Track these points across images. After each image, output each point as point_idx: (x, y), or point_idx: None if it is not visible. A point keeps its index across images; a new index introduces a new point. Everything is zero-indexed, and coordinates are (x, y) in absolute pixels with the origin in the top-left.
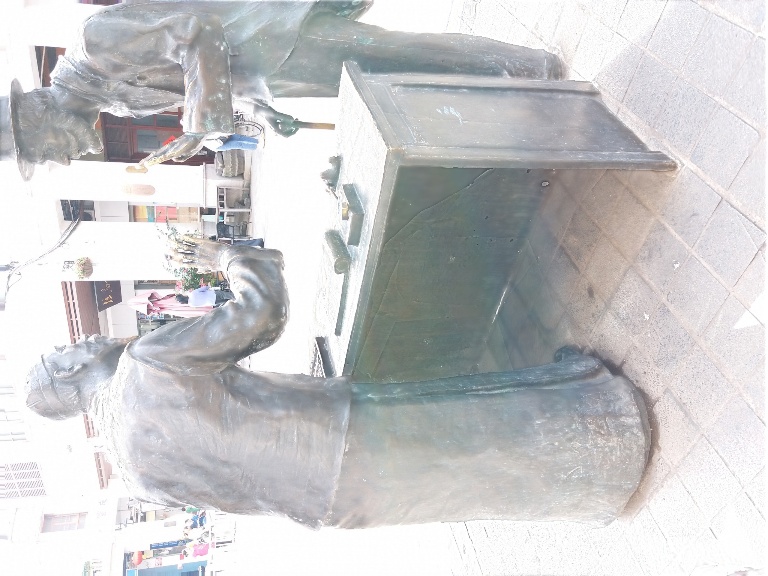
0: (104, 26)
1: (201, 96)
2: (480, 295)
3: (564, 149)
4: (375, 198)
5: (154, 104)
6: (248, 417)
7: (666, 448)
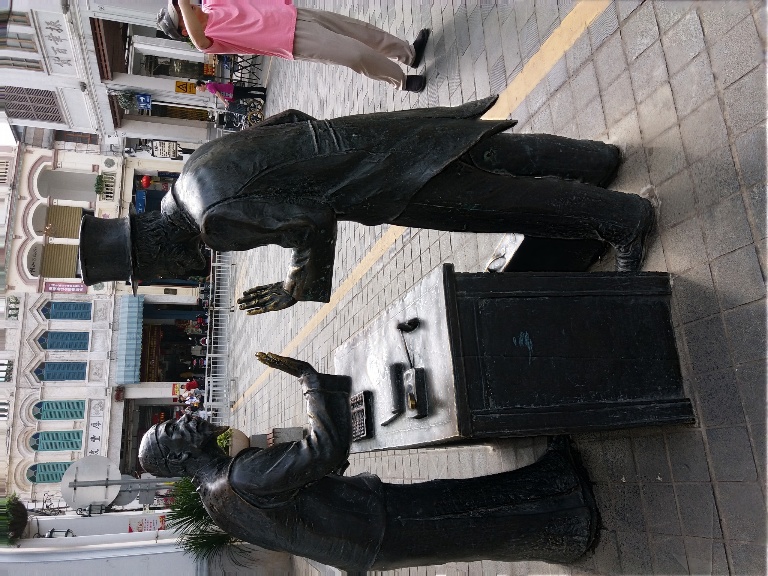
0: (225, 222)
1: (306, 279)
2: None
3: (607, 406)
4: (439, 433)
5: None
6: (311, 536)
7: (598, 557)
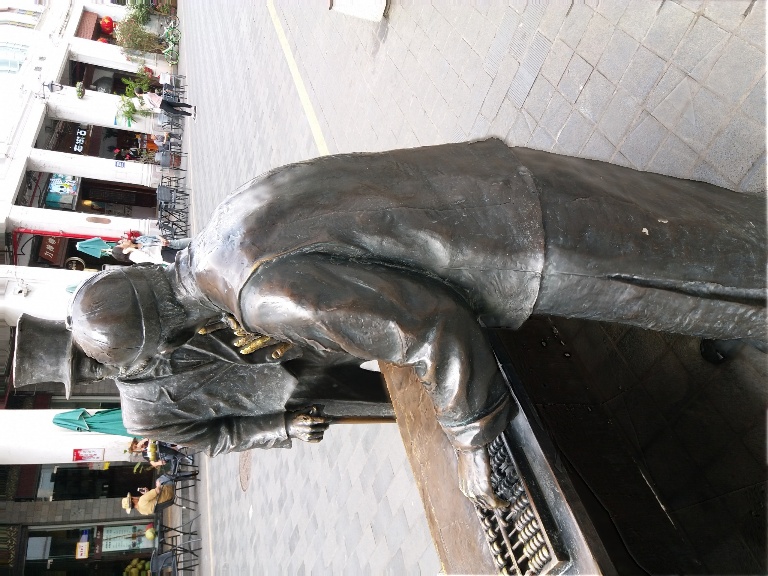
0: None
1: None
2: (619, 480)
3: None
4: None
5: (196, 366)
6: None
7: None
